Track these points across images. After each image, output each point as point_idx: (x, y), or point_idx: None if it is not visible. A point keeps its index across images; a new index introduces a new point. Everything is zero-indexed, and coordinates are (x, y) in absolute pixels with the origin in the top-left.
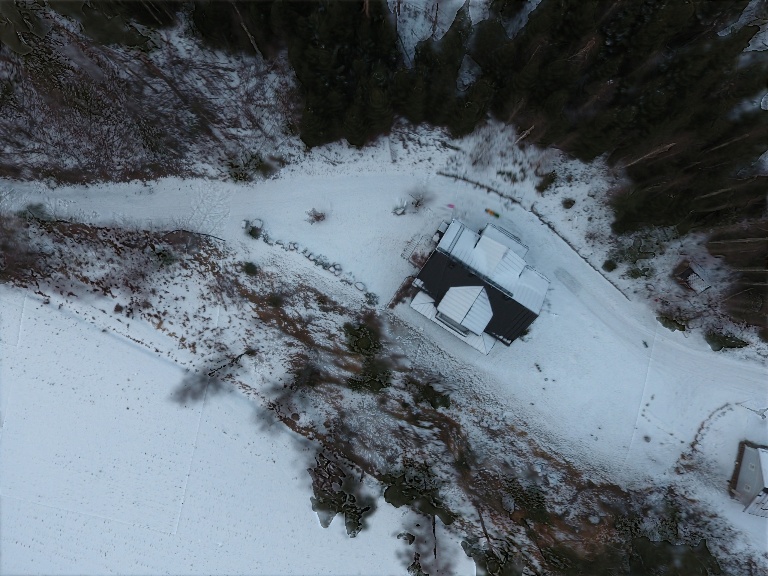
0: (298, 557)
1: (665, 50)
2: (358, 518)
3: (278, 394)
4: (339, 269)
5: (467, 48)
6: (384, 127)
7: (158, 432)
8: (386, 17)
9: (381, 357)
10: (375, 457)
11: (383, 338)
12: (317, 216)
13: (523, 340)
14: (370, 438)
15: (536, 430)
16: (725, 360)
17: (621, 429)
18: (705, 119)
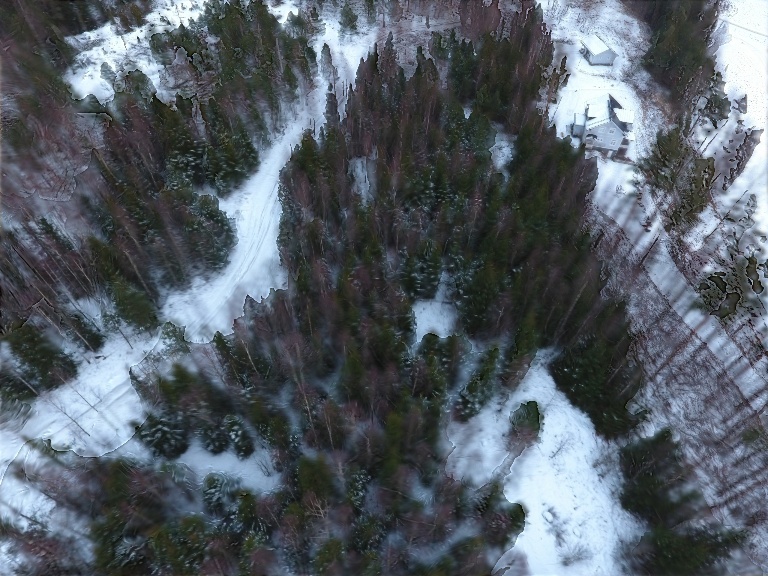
0: None
1: None
2: None
3: (713, 227)
4: None
5: None
6: None
7: None
8: None
9: None
10: None
11: None
12: None
13: None
14: None
15: None
16: None
17: (615, 92)
18: None
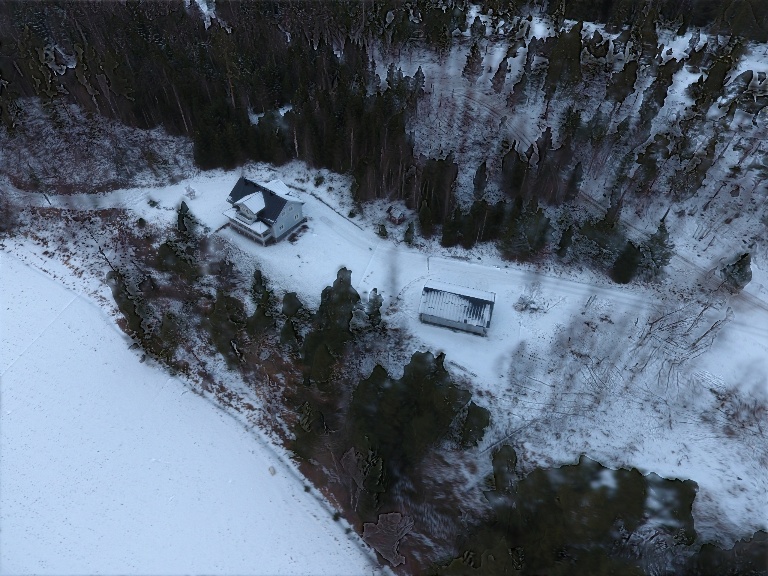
0: (72, 428)
1: None
2: (136, 315)
3: None
4: (194, 216)
5: (279, 124)
6: (241, 162)
7: (19, 325)
8: (242, 107)
9: (203, 266)
10: (177, 348)
11: (208, 253)
12: (191, 192)
13: (293, 244)
14: (179, 335)
15: None
16: (420, 256)
17: None
18: None
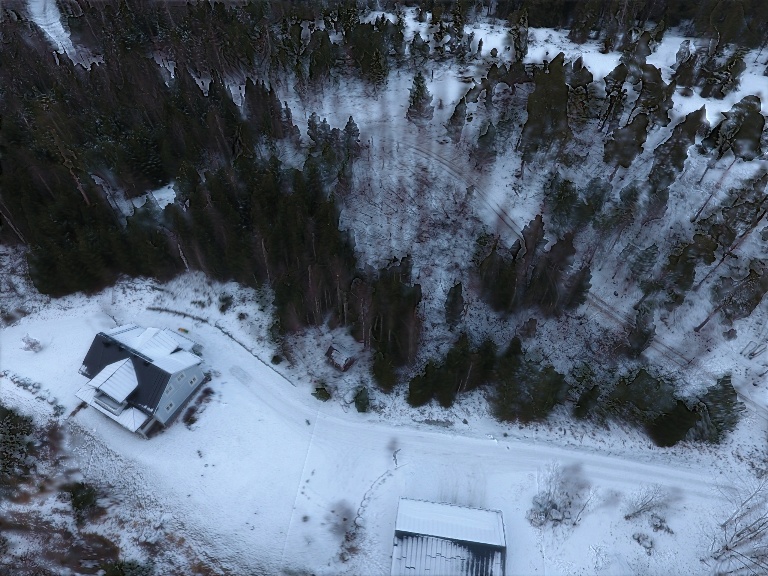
0: None
1: None
2: None
3: None
4: (37, 387)
5: (160, 221)
6: (110, 281)
7: None
8: (99, 203)
9: (54, 476)
10: None
11: (61, 452)
12: (32, 344)
13: (190, 429)
14: None
15: (192, 530)
16: (382, 428)
17: (279, 512)
18: None
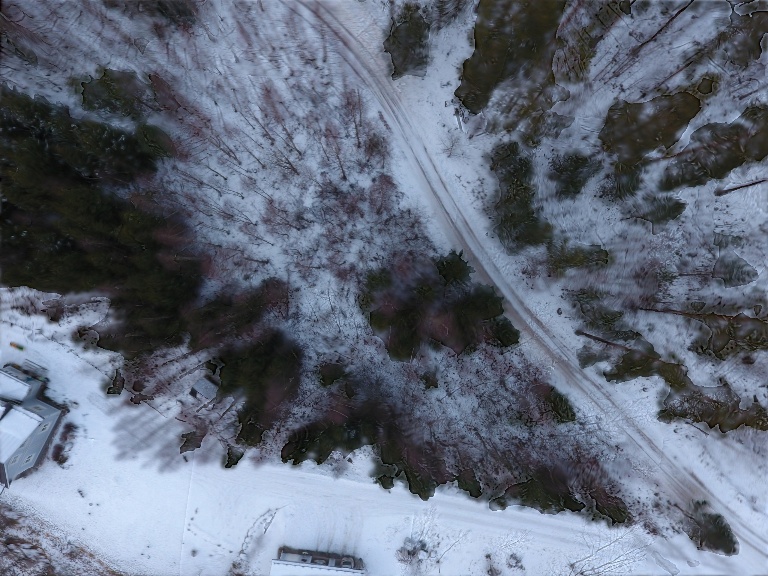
0: None
1: (119, 183)
2: None
3: None
4: None
5: None
6: None
7: None
8: None
9: None
10: None
11: None
12: None
13: (63, 468)
14: None
15: (96, 552)
16: (263, 467)
17: (170, 545)
18: (95, 269)
